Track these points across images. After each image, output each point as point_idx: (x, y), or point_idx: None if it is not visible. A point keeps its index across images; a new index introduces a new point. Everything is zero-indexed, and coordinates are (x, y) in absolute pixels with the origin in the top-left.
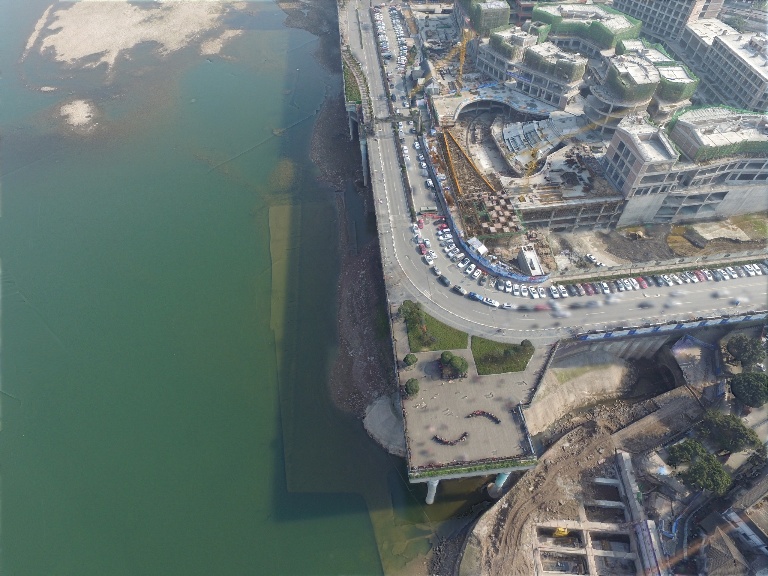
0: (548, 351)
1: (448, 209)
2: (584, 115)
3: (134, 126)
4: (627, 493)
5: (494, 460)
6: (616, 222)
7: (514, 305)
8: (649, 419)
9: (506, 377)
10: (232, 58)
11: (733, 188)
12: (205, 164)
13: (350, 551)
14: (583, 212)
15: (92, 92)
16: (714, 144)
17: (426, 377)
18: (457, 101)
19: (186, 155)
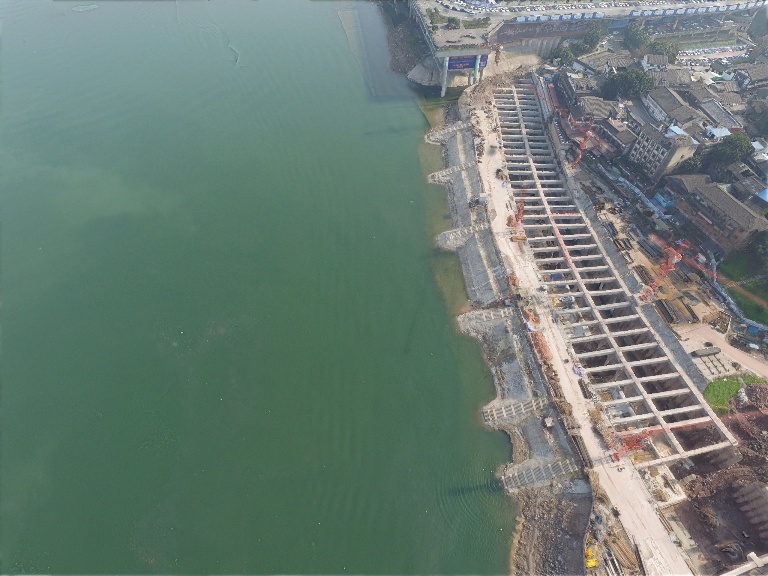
0: (498, 24)
1: None
2: None
3: None
4: None
5: (473, 44)
6: None
7: (482, 13)
8: None
9: (478, 29)
10: None
11: None
12: None
13: (407, 108)
14: None
15: None
16: None
17: (441, 29)
18: None
19: None
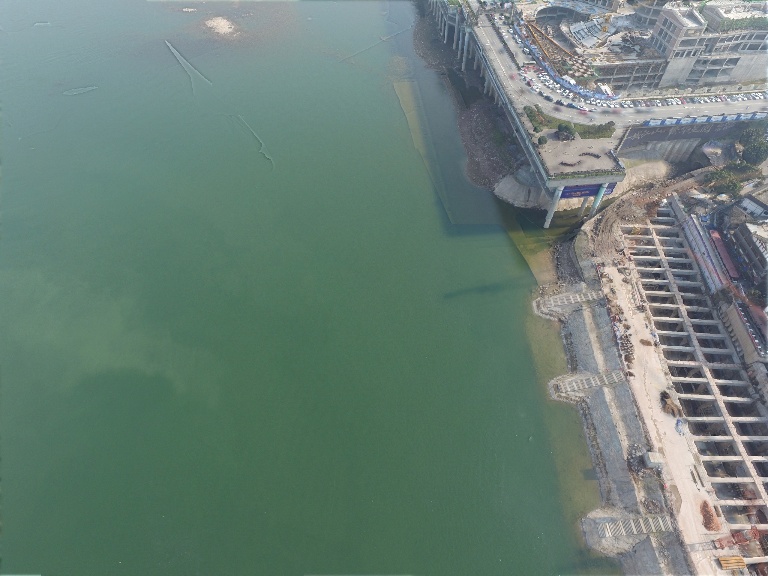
0: (624, 130)
1: (544, 63)
2: (632, 14)
3: (269, 34)
4: (676, 213)
5: (600, 170)
6: (659, 82)
7: (599, 110)
8: (688, 181)
9: (600, 140)
10: None
11: (744, 55)
12: (334, 58)
13: (500, 248)
14: (636, 71)
15: (226, 12)
16: (731, 18)
17: (549, 140)
18: (534, 6)
19: (317, 52)
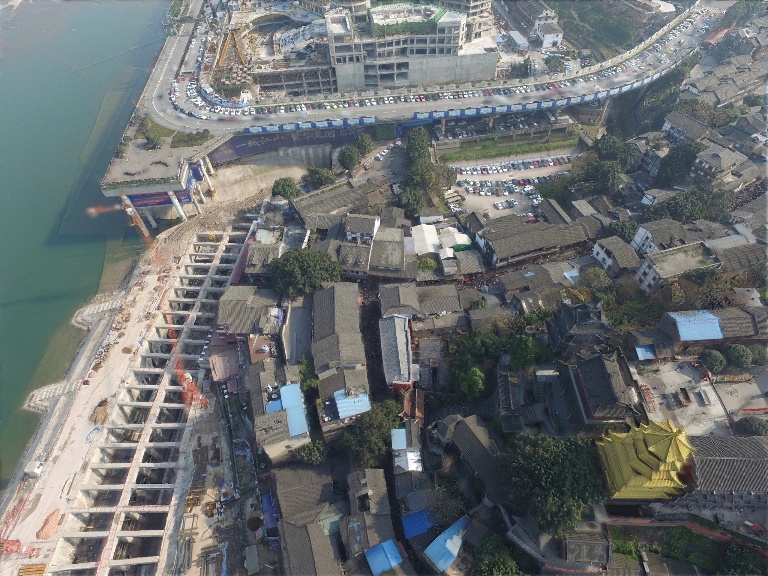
0: None
1: (201, 71)
2: None
3: (21, 46)
4: None
5: (153, 179)
6: (336, 88)
7: (215, 118)
8: None
9: (187, 149)
10: (115, 1)
11: (411, 59)
12: (68, 69)
13: (87, 258)
14: (306, 78)
15: None
16: (385, 24)
17: (136, 149)
18: (251, 14)
19: (56, 64)
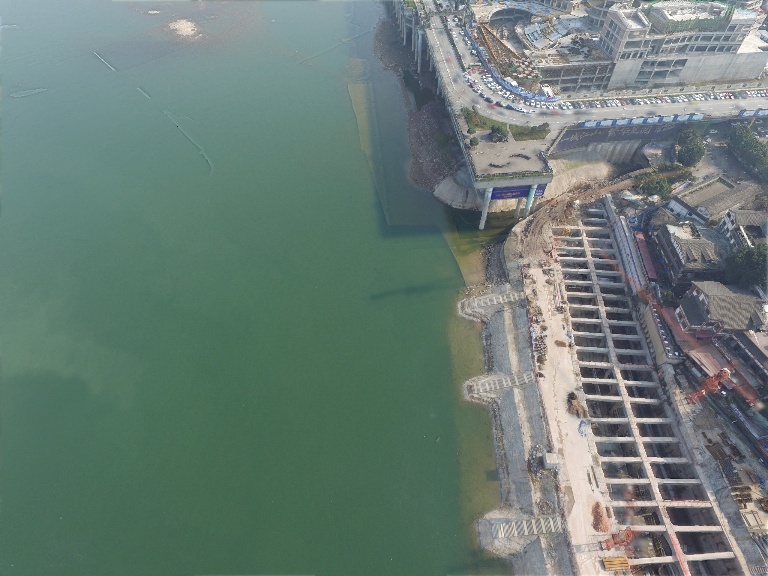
0: (559, 132)
1: (489, 64)
2: (585, 16)
3: (231, 36)
4: (609, 214)
5: (527, 172)
6: (607, 84)
7: (537, 111)
8: (625, 182)
9: (533, 142)
10: None
11: (691, 56)
12: (293, 60)
13: (433, 249)
14: (584, 73)
15: (191, 14)
16: (676, 20)
17: (482, 141)
18: (489, 8)
19: (277, 54)
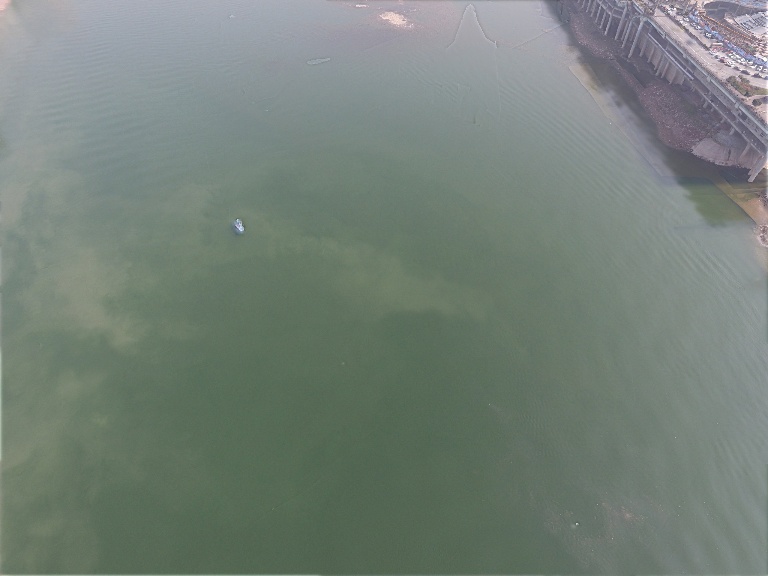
0: None
1: None
2: None
3: (441, 26)
4: None
5: None
6: None
7: None
8: None
9: None
10: None
11: None
12: (506, 45)
13: (712, 196)
14: None
15: (394, 8)
16: None
17: None
18: (700, 1)
19: None
